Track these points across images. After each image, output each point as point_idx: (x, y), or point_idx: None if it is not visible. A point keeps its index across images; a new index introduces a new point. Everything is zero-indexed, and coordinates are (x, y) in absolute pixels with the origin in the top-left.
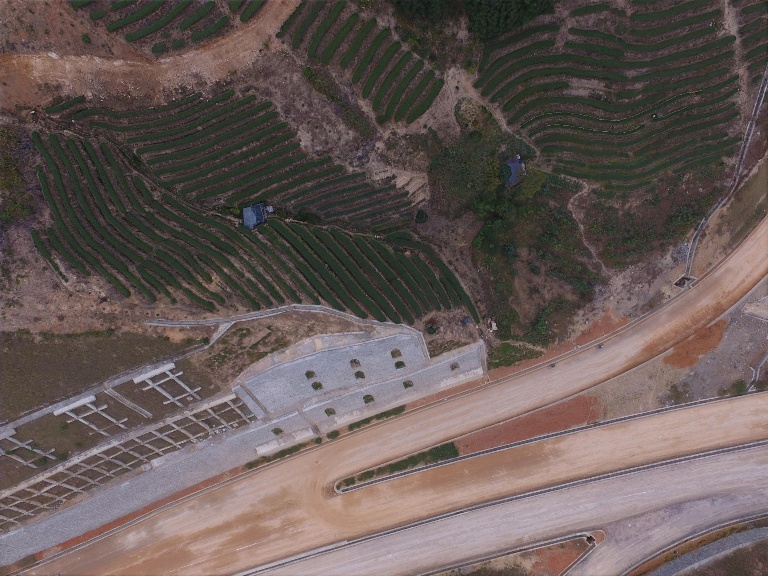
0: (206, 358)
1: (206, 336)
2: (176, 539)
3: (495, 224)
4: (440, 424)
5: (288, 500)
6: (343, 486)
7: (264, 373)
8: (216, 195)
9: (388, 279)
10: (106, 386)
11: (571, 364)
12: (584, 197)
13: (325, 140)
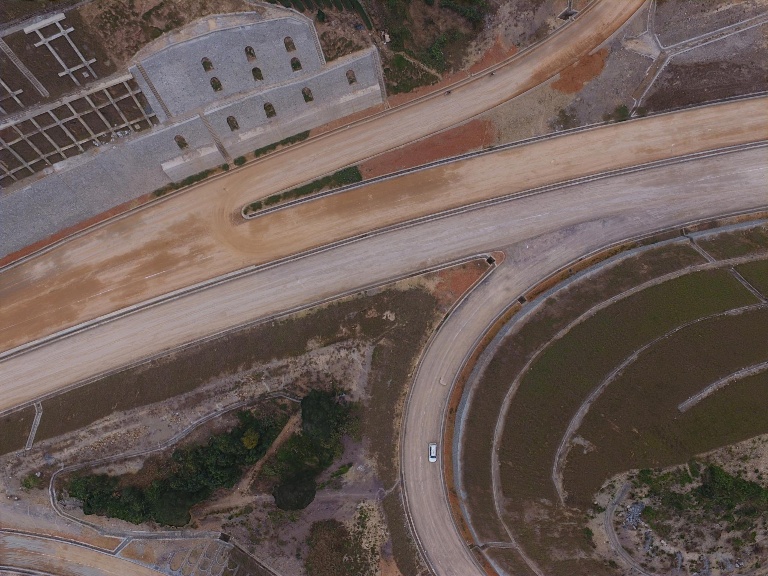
0: (97, 15)
1: None
2: (84, 268)
3: None
4: (344, 150)
5: (196, 227)
6: (250, 211)
7: (159, 53)
8: None
9: None
10: None
11: (466, 92)
12: None
13: None
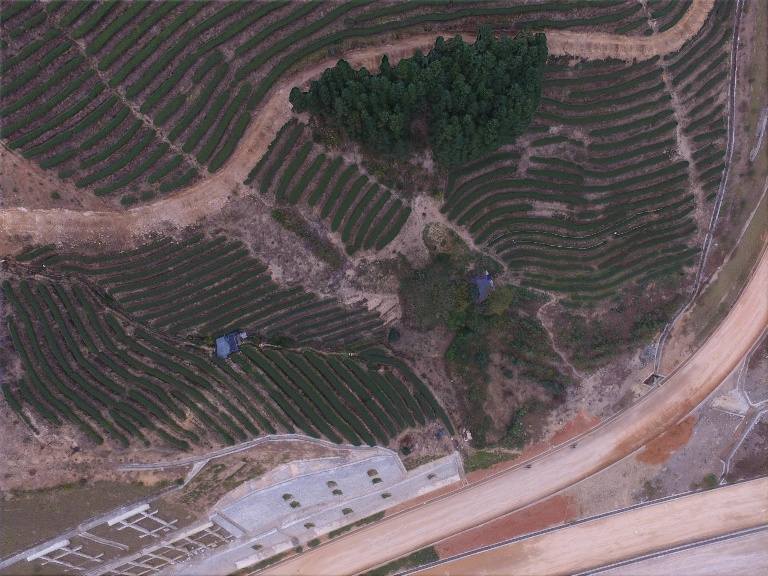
0: (181, 496)
1: (180, 477)
2: None
3: (467, 337)
4: (420, 528)
5: None
6: None
7: (241, 500)
8: (189, 327)
9: (362, 399)
10: (80, 529)
11: (547, 464)
12: (552, 307)
13: (296, 272)
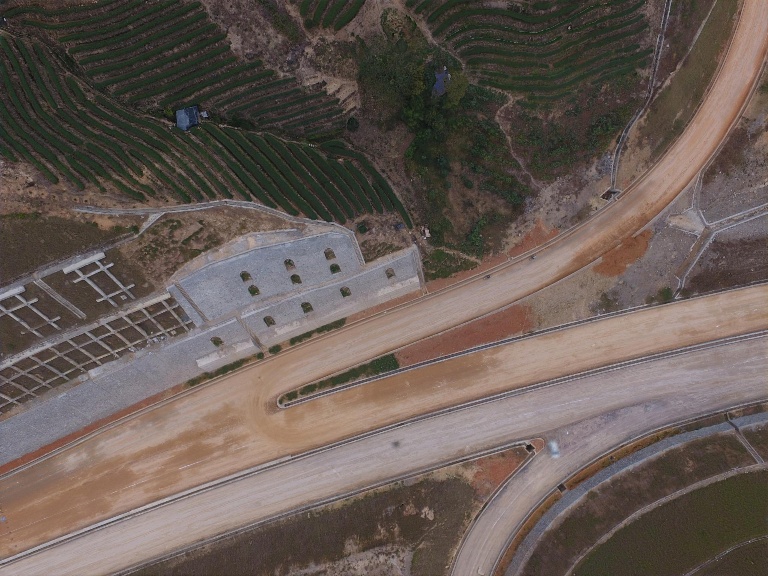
0: (137, 249)
1: (135, 224)
2: (118, 459)
3: (425, 134)
4: (380, 337)
5: (231, 416)
6: (286, 400)
7: (198, 272)
8: (149, 97)
9: (321, 183)
10: (35, 277)
11: (506, 275)
12: (509, 109)
13: (255, 43)
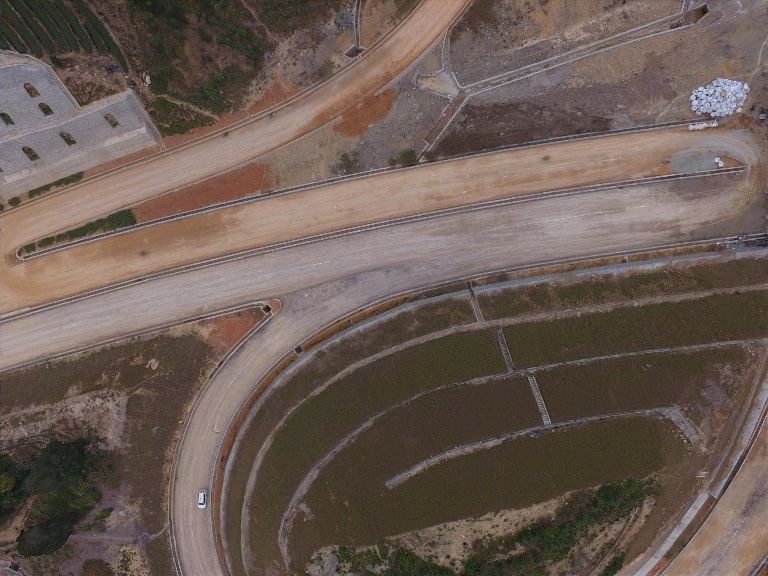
0: None
1: None
2: None
3: None
4: (118, 192)
5: None
6: (24, 252)
7: None
8: None
9: (24, 18)
10: None
11: (245, 133)
12: None
13: None
